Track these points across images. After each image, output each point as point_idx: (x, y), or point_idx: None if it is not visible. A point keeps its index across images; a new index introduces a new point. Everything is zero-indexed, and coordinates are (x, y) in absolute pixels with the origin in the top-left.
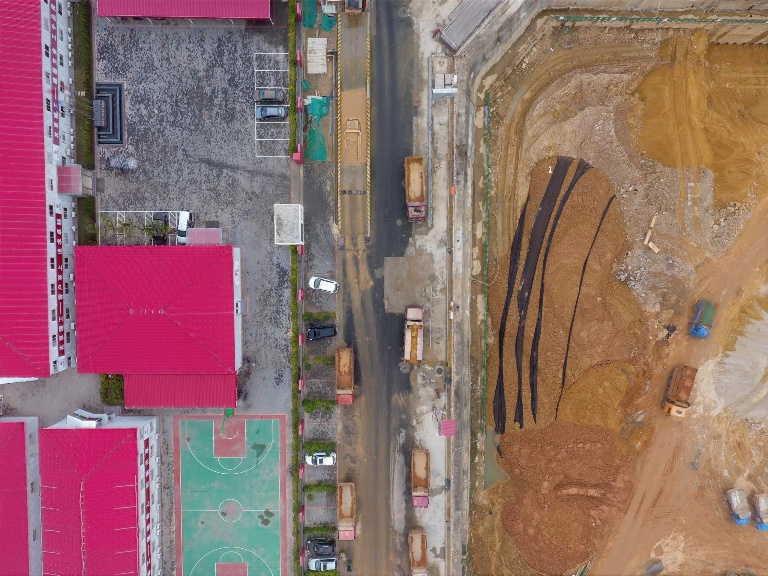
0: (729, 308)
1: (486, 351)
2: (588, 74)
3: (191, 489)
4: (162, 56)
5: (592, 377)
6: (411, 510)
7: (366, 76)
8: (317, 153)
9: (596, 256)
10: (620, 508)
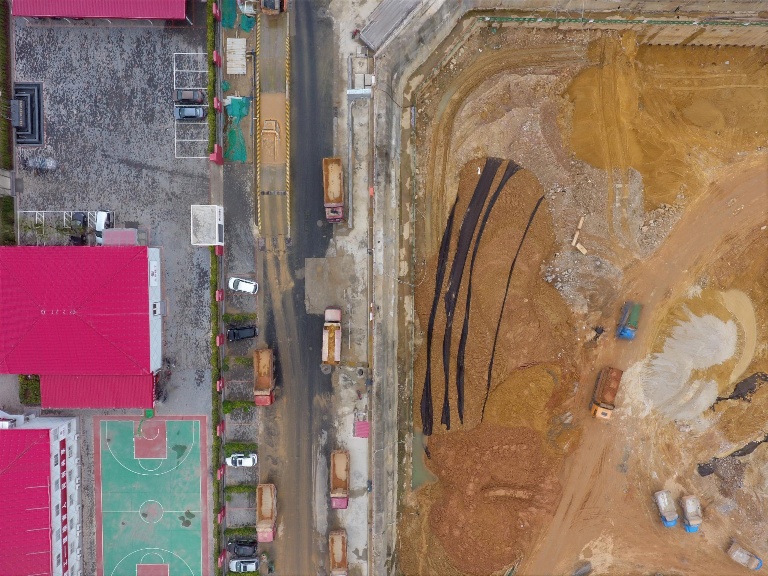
0: (657, 310)
1: (414, 352)
2: (515, 75)
3: (112, 490)
4: (81, 56)
5: (518, 379)
6: (333, 511)
7: (285, 77)
8: (237, 154)
9: (524, 257)
10: (548, 510)
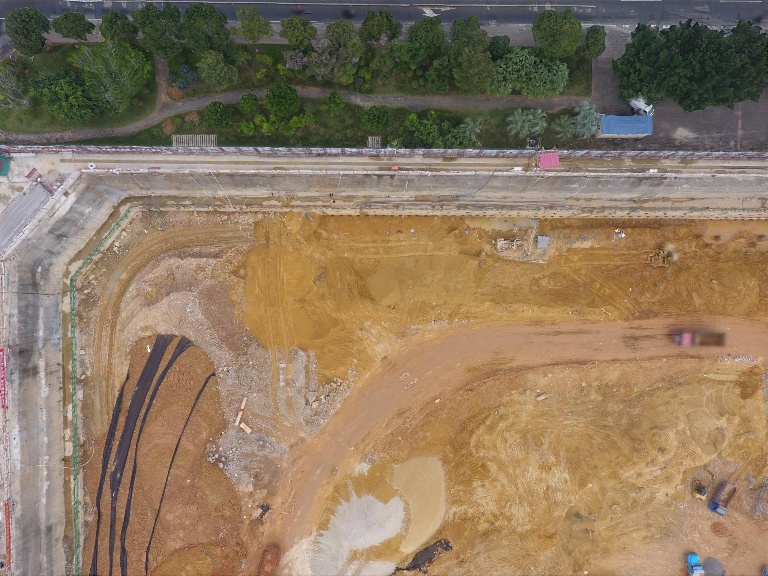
0: (323, 487)
1: (85, 529)
2: (175, 259)
3: None
4: None
5: (174, 562)
6: None
7: None
8: None
9: (189, 437)
10: None
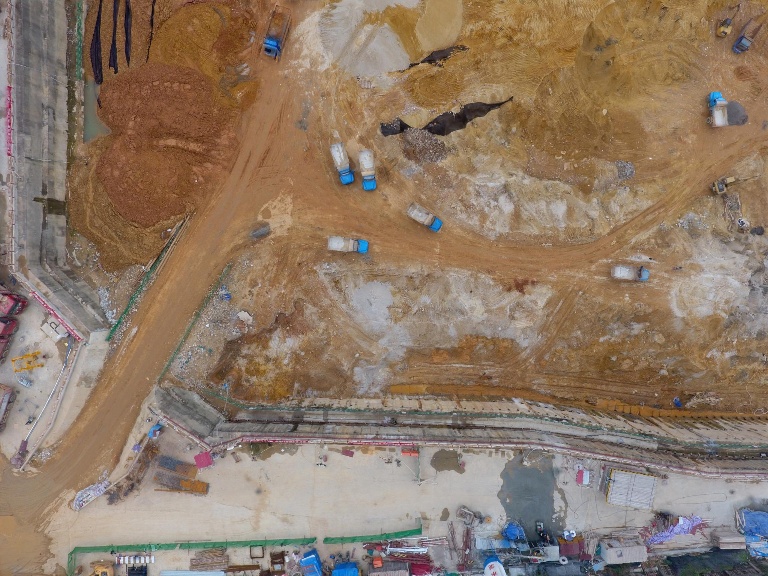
0: None
1: None
2: None
3: None
4: None
5: (181, 14)
6: None
7: None
8: None
9: None
10: (225, 166)
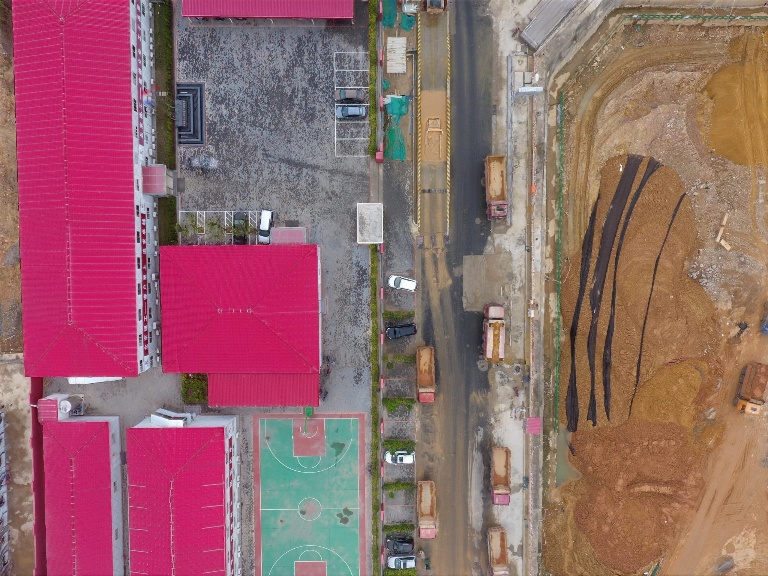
0: None
1: (557, 349)
2: (660, 72)
3: (270, 488)
4: (242, 56)
5: (666, 375)
6: (489, 508)
7: (446, 75)
8: (396, 152)
9: (668, 254)
10: (692, 505)
